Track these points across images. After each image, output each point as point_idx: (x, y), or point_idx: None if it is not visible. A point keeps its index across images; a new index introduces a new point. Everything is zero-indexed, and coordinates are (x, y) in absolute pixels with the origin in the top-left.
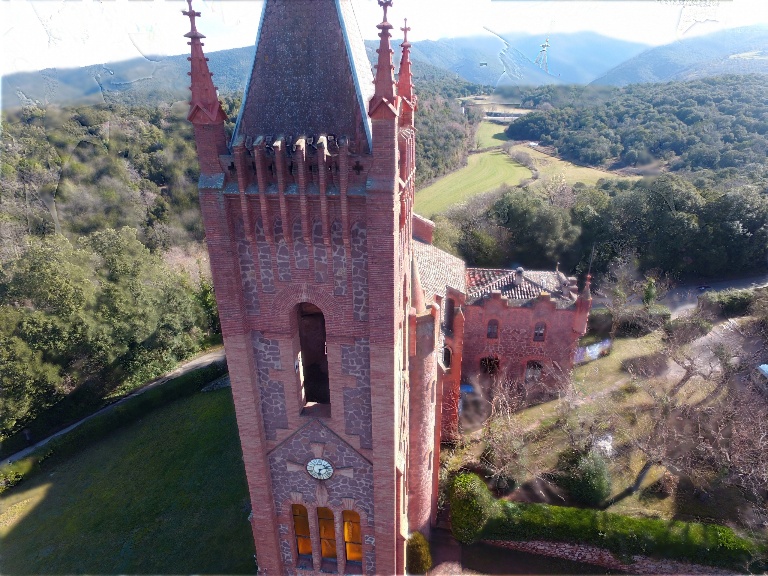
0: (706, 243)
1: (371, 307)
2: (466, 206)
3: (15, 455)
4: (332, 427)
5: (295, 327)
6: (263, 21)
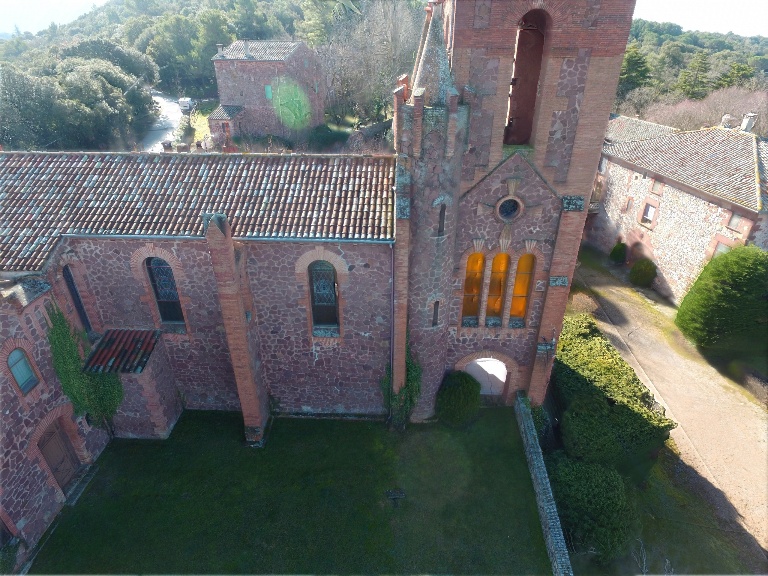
0: (103, 126)
1: None
2: None
3: None
4: None
5: None
6: None
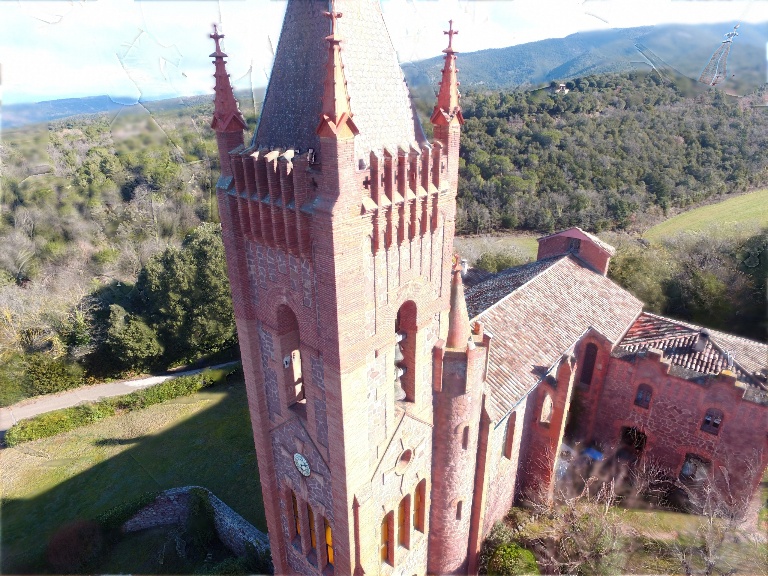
0: None
1: (322, 326)
2: (702, 236)
3: (221, 365)
4: (308, 430)
5: (289, 326)
6: (281, 37)
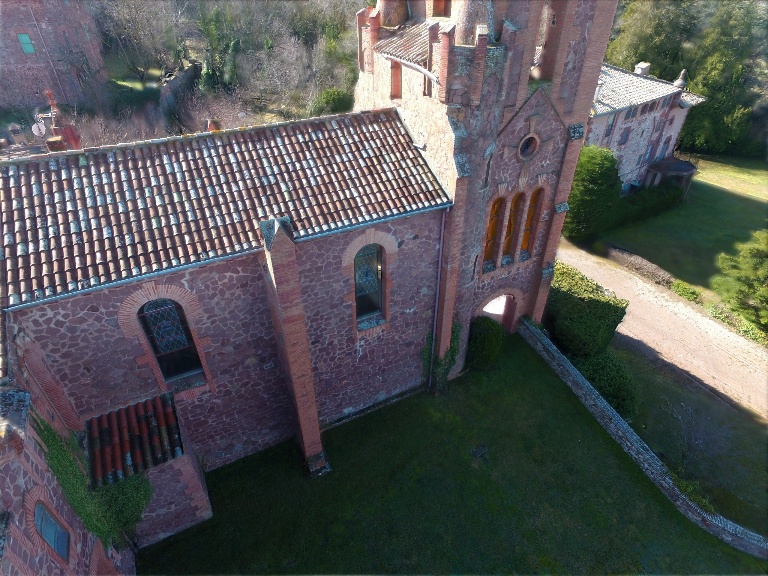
0: None
1: None
2: None
3: None
4: None
5: None
6: None
